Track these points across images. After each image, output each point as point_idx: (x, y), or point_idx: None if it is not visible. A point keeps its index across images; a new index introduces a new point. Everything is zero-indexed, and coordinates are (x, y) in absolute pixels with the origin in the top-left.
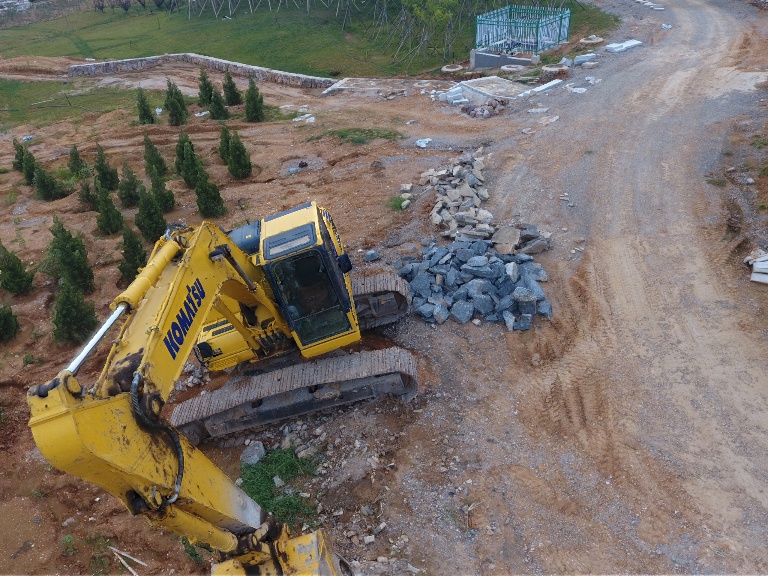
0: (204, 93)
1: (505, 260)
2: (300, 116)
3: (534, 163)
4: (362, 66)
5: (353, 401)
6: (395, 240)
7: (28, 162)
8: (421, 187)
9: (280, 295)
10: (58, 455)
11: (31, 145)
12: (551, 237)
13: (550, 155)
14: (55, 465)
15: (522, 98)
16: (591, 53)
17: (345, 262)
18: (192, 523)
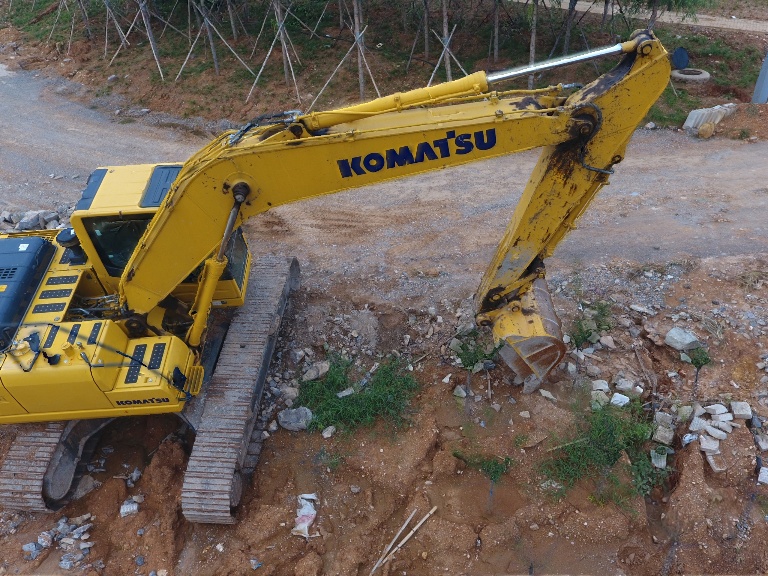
0: None
1: None
2: None
3: None
4: None
5: None
6: None
7: None
8: None
9: None
10: None
11: None
12: None
13: None
14: None
15: None
16: None
17: None
18: None
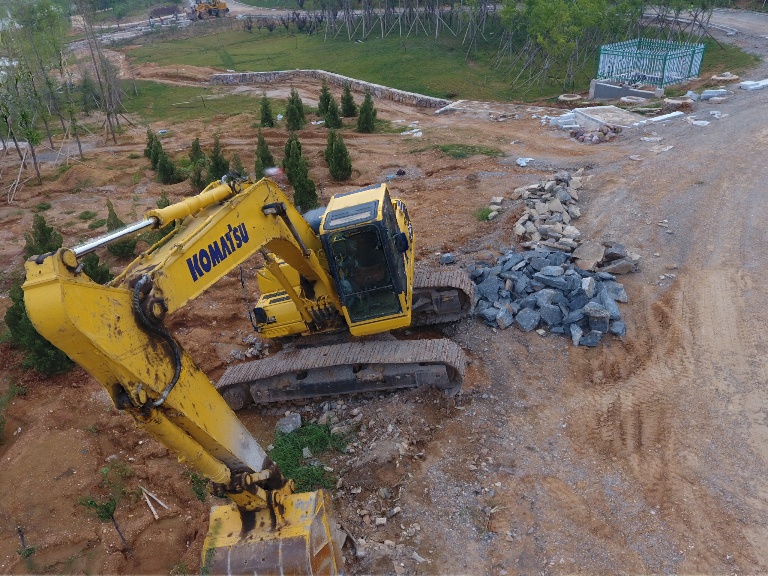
0: (323, 104)
1: (583, 275)
2: (409, 130)
3: (636, 188)
4: (479, 90)
5: (395, 387)
6: (474, 247)
7: (156, 149)
8: (512, 201)
9: (335, 267)
10: (44, 321)
11: (164, 138)
12: (640, 260)
13: (655, 182)
14: (41, 332)
15: (637, 127)
16: (722, 89)
17: (402, 241)
18: (180, 437)
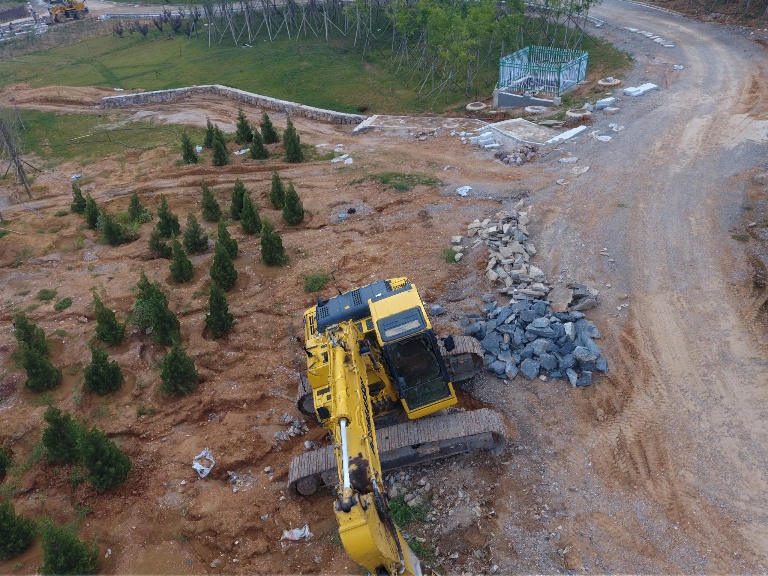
0: (242, 131)
1: (562, 319)
2: (338, 157)
3: (572, 216)
4: (388, 102)
5: (450, 455)
6: (455, 294)
7: (91, 207)
8: (470, 239)
9: (394, 370)
10: (357, 552)
11: (82, 184)
12: (598, 294)
13: (586, 208)
14: None
15: (551, 145)
16: (611, 97)
17: (451, 343)
18: None
